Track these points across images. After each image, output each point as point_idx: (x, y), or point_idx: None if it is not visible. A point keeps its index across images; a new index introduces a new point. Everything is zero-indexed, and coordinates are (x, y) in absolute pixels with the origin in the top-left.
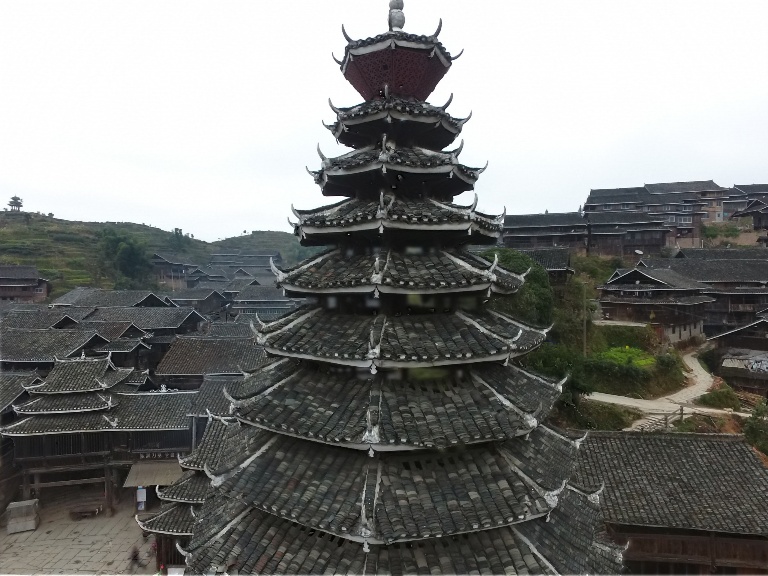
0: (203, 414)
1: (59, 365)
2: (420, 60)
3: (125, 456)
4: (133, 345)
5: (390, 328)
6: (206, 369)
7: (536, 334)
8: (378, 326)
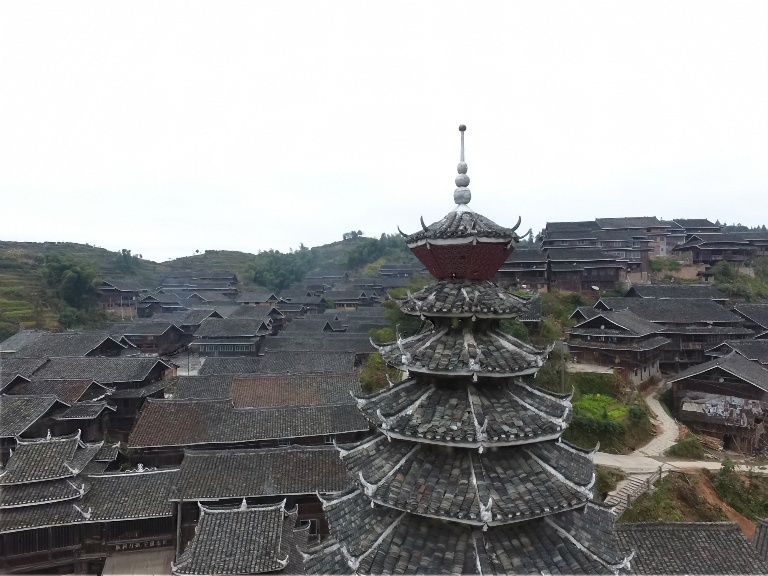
0: (187, 498)
1: (21, 448)
2: (497, 251)
3: (98, 548)
4: (98, 410)
5: (493, 554)
6: (183, 439)
7: (606, 514)
8: (485, 559)
